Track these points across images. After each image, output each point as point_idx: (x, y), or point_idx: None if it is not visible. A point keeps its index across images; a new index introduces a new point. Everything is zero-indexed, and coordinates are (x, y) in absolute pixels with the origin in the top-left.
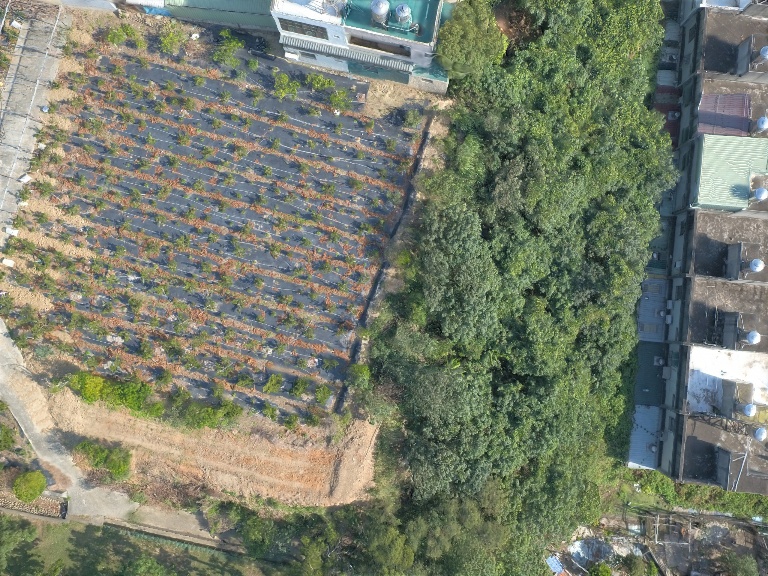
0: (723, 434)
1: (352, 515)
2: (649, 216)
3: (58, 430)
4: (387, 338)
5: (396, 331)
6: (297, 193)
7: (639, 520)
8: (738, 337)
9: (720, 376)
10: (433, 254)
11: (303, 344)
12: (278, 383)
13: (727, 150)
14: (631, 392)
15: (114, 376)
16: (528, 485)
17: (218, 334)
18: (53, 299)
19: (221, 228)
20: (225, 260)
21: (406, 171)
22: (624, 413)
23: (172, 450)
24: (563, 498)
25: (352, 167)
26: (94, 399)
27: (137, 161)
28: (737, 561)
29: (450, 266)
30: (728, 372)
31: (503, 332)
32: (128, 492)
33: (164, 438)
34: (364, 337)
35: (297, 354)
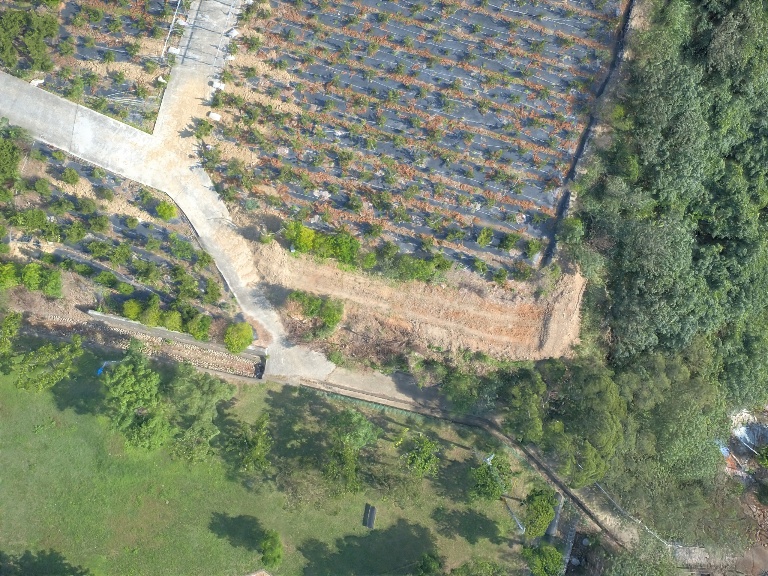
0: None
1: None
2: None
3: (264, 284)
4: (593, 196)
5: (605, 187)
6: (505, 51)
7: None
8: None
9: None
10: (653, 104)
11: (510, 201)
12: (489, 236)
13: None
14: None
15: (320, 231)
16: None
17: (426, 189)
18: (259, 153)
19: (428, 85)
20: (432, 117)
21: (613, 31)
22: None
23: (380, 303)
24: (762, 361)
25: (559, 27)
26: (306, 249)
27: (345, 18)
28: None
29: (667, 118)
30: None
31: (705, 194)
32: (326, 352)
33: (372, 291)
34: (572, 194)
35: (505, 210)
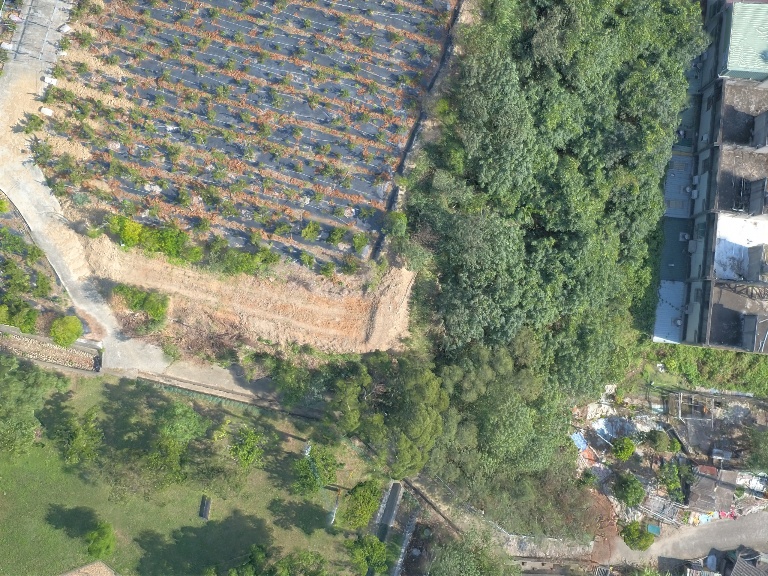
0: (748, 302)
1: (388, 360)
2: (678, 84)
3: (95, 278)
4: (423, 190)
5: (433, 181)
6: (335, 46)
7: (662, 400)
8: (765, 201)
9: (746, 245)
10: (472, 98)
11: (340, 195)
12: (316, 230)
13: (756, 17)
14: (657, 266)
15: (151, 225)
16: (560, 339)
17: (256, 183)
18: (91, 148)
19: (259, 80)
20: (263, 112)
21: (443, 26)
22: (650, 285)
23: (209, 297)
24: (594, 353)
25: (390, 21)
26: (133, 243)
27: (176, 13)
28: (760, 434)
29: (488, 112)
30: (754, 241)
31: (537, 187)
32: (163, 345)
33: (201, 285)
34: (401, 188)
35: (334, 204)
